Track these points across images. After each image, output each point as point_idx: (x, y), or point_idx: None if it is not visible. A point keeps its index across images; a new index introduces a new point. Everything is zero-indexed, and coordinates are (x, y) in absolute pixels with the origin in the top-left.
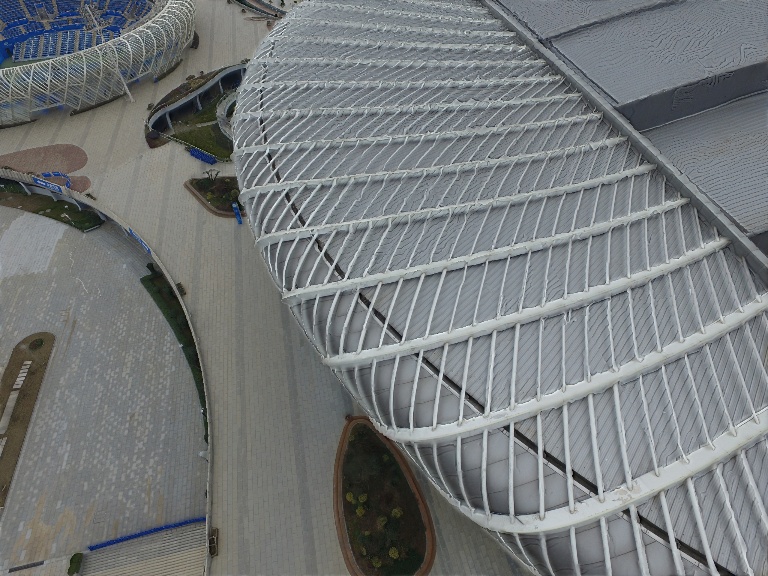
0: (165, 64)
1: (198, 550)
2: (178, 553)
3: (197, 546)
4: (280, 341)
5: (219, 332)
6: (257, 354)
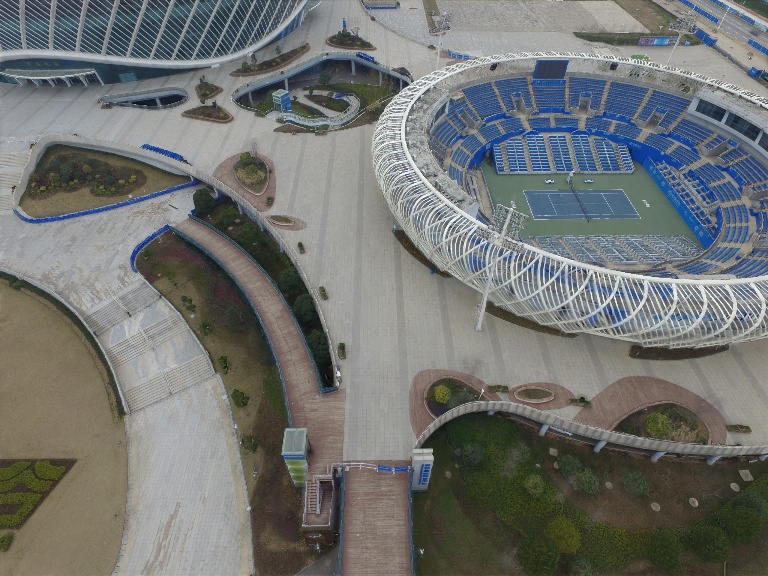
0: None
1: (367, 3)
2: (372, 4)
3: (367, 4)
4: (335, 8)
5: (357, 11)
6: (344, 7)
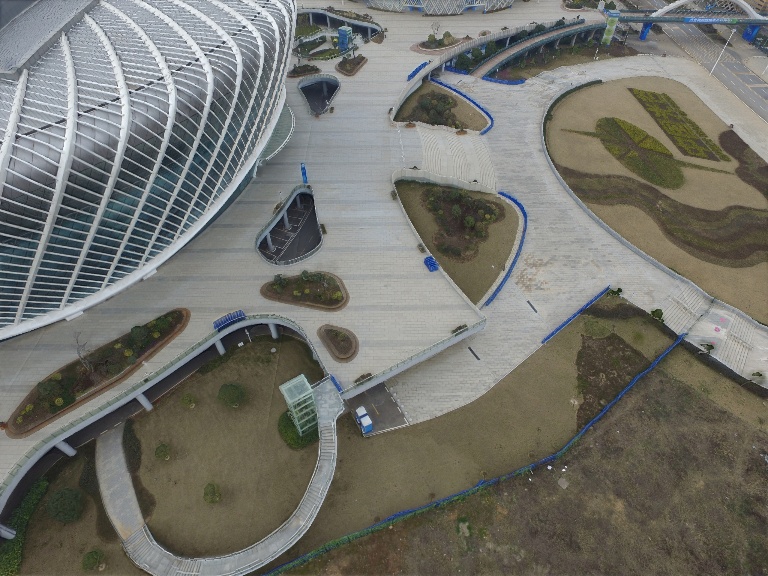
0: (382, 3)
1: None
2: None
3: None
4: None
5: None
6: None
